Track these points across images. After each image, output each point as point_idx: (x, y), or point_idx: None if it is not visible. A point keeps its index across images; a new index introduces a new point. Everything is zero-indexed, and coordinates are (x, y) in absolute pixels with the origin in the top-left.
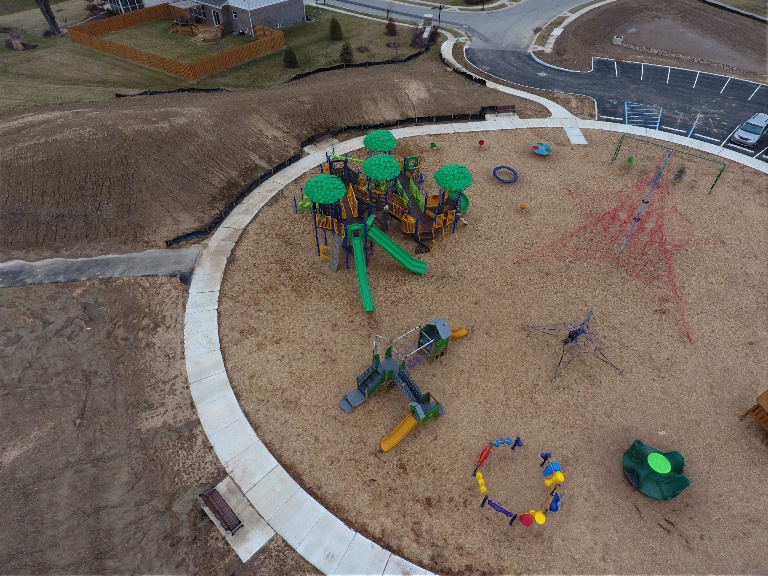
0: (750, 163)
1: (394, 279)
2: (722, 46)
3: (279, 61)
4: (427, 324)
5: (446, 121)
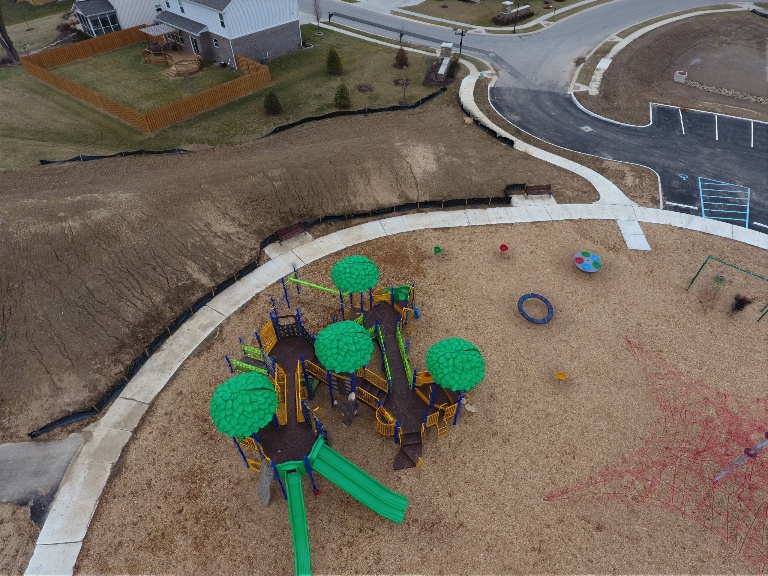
0: None
1: (355, 526)
2: None
3: (260, 105)
4: None
5: (458, 206)
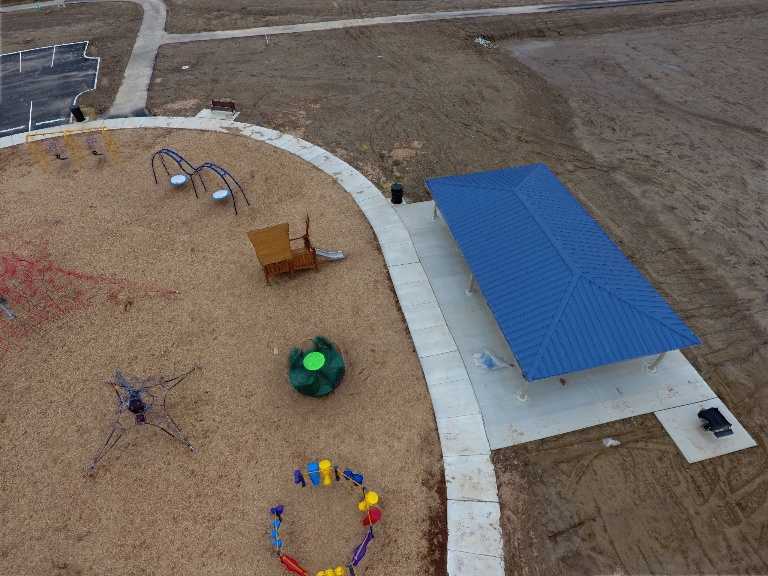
0: None
1: None
2: None
3: None
4: None
5: None
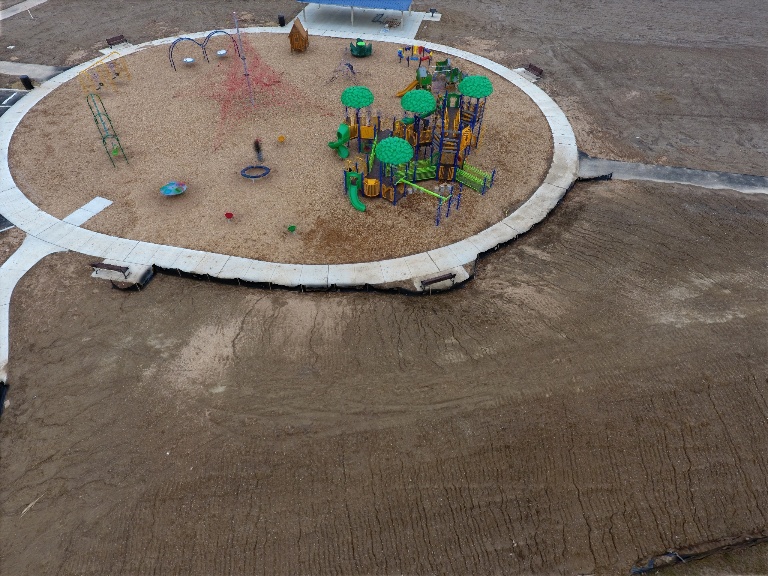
0: (5, 134)
1: None
2: None
3: None
4: (427, 75)
5: None
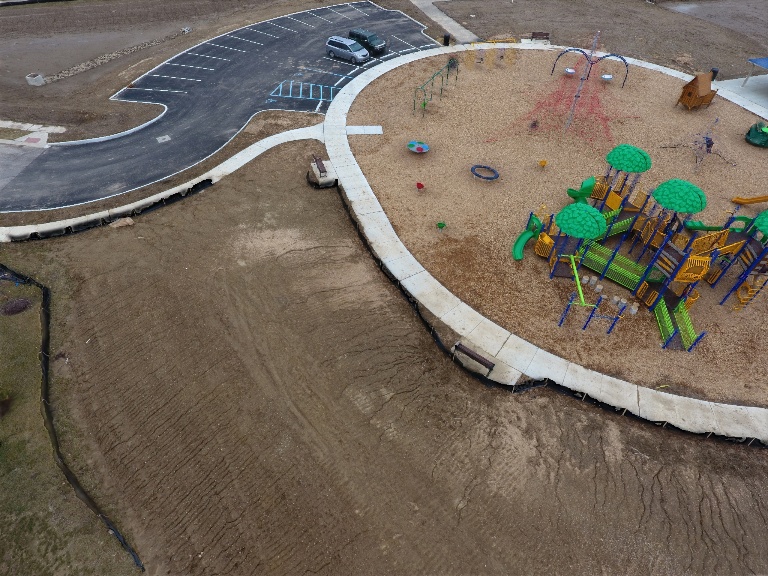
0: (395, 64)
1: None
2: (89, 34)
3: None
4: None
5: None
